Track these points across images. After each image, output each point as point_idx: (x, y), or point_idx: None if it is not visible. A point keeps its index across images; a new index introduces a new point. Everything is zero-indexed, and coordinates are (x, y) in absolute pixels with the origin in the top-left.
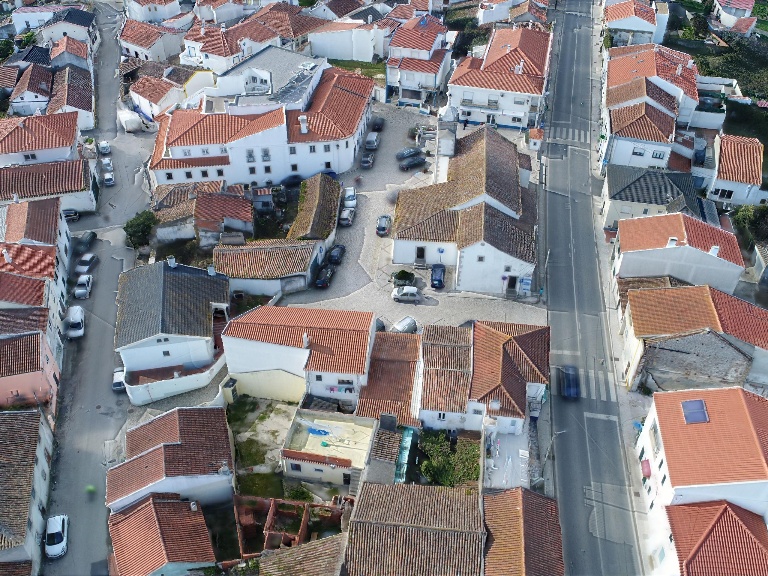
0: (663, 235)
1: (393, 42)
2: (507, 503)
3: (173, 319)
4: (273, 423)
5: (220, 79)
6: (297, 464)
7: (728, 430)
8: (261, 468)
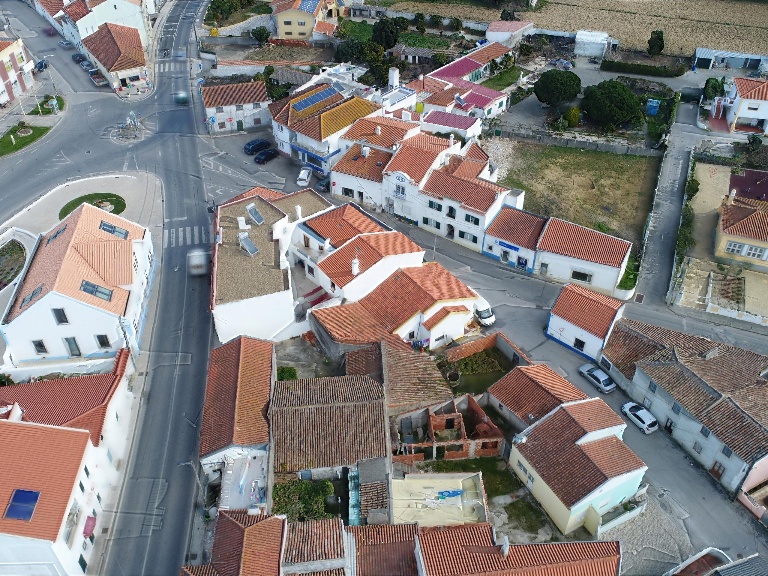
0: None
1: None
2: (248, 435)
3: None
4: None
5: None
6: None
7: (2, 477)
8: (505, 501)
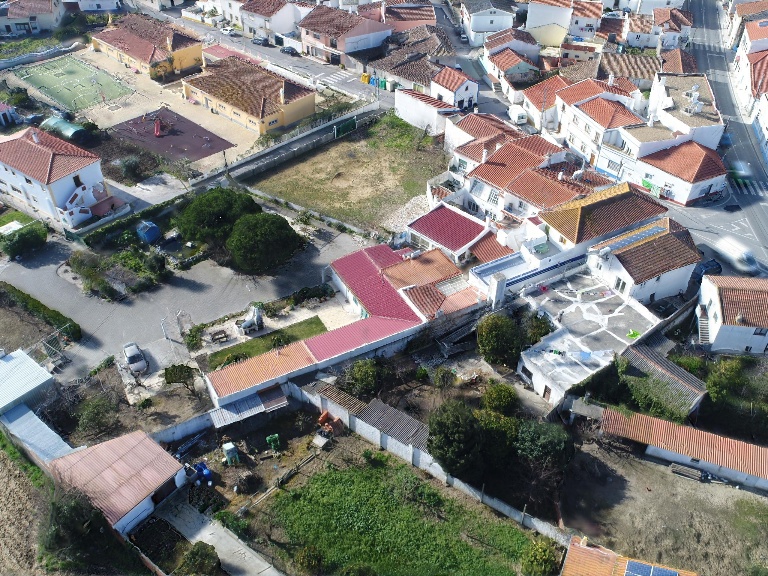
0: None
1: None
2: None
3: (497, 6)
4: (547, 51)
5: None
6: (567, 53)
7: None
8: None
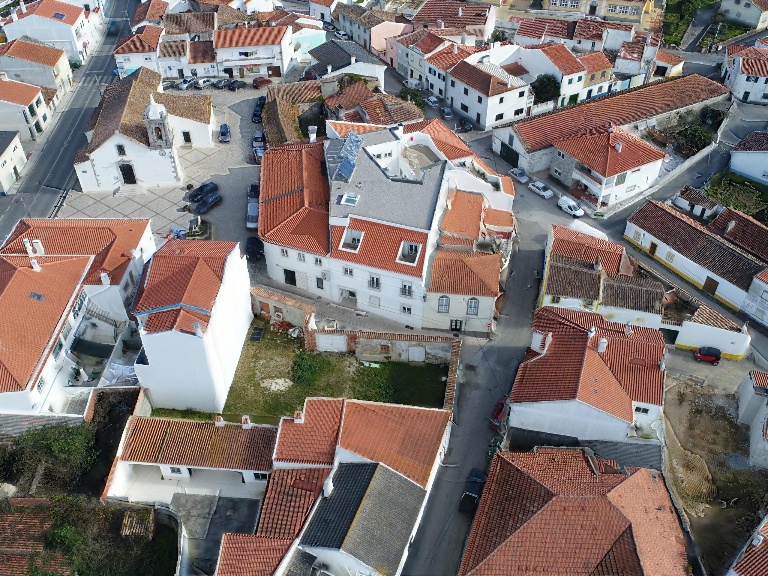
0: (5, 87)
1: (233, 244)
2: None
3: None
4: None
5: (444, 163)
6: None
7: None
8: None
